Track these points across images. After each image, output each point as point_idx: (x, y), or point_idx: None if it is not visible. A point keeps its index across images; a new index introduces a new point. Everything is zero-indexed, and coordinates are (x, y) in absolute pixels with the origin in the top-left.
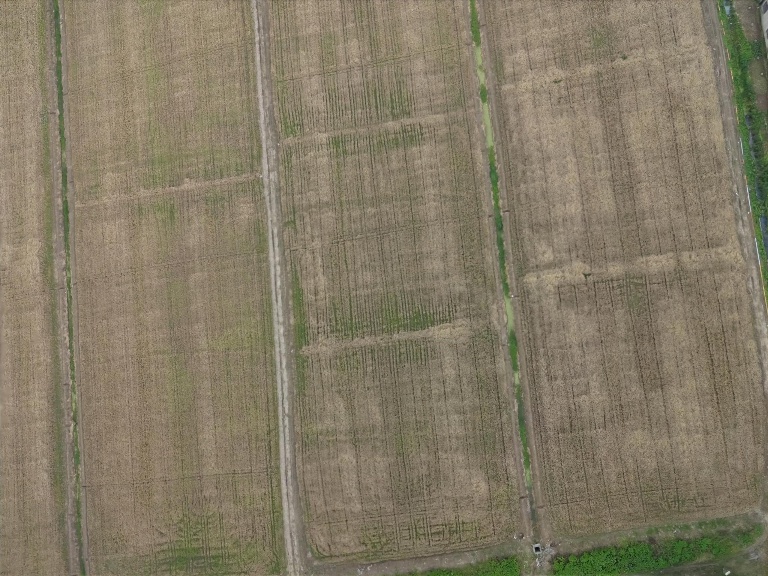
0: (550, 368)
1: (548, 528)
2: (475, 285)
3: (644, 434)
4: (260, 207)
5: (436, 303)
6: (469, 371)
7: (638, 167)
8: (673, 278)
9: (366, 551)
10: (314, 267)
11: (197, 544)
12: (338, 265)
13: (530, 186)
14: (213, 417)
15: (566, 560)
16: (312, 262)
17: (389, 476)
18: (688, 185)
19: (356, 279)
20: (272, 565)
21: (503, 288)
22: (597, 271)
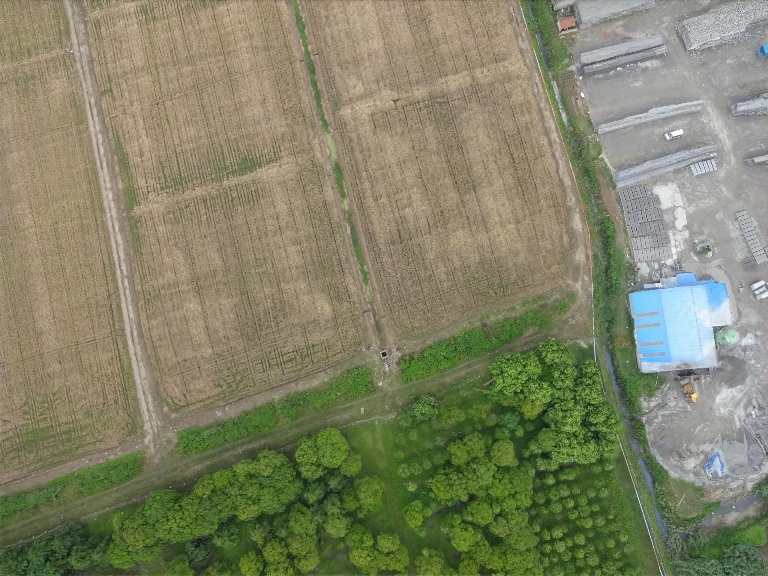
0: (374, 189)
1: (392, 335)
2: (295, 124)
3: (465, 233)
4: (74, 80)
5: (261, 146)
6: (300, 204)
7: (427, 1)
8: (471, 93)
9: (222, 392)
10: (136, 130)
11: (45, 423)
12: (160, 125)
13: (334, 29)
14: (48, 292)
15: (411, 358)
16: (134, 126)
17: (236, 316)
18: (472, 11)
19: (180, 135)
20: (128, 427)
21: (322, 124)
22: (404, 96)
